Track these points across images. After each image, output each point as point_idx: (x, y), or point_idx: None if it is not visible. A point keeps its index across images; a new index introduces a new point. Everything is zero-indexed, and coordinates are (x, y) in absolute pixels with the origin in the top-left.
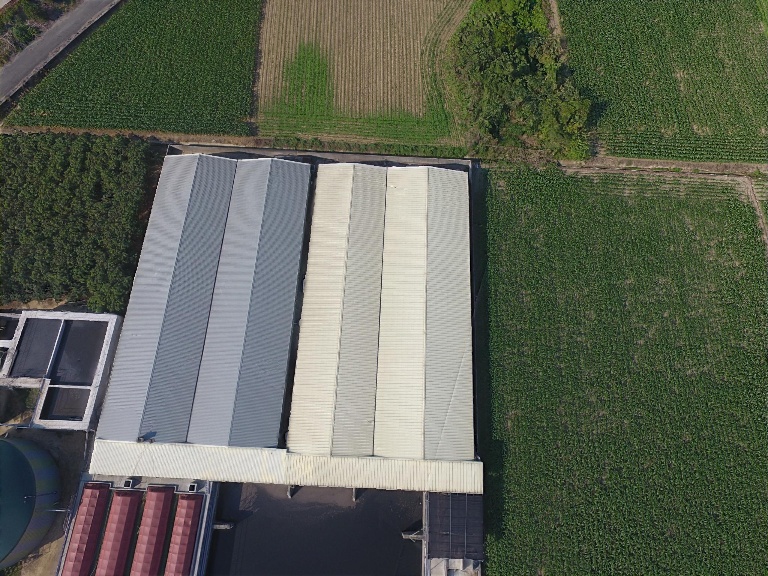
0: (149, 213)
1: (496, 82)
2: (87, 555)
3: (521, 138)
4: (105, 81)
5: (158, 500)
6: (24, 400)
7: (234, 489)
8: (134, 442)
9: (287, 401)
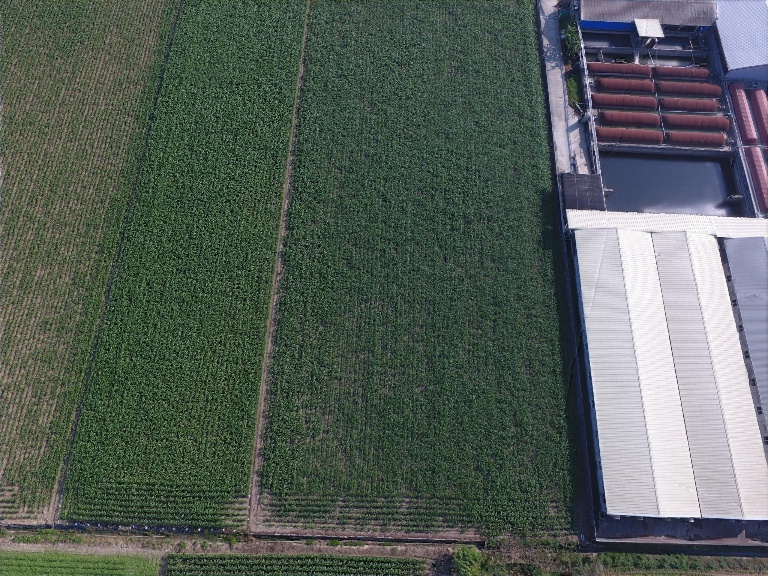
0: None
1: None
2: None
3: None
4: None
5: None
6: None
7: None
8: None
9: None
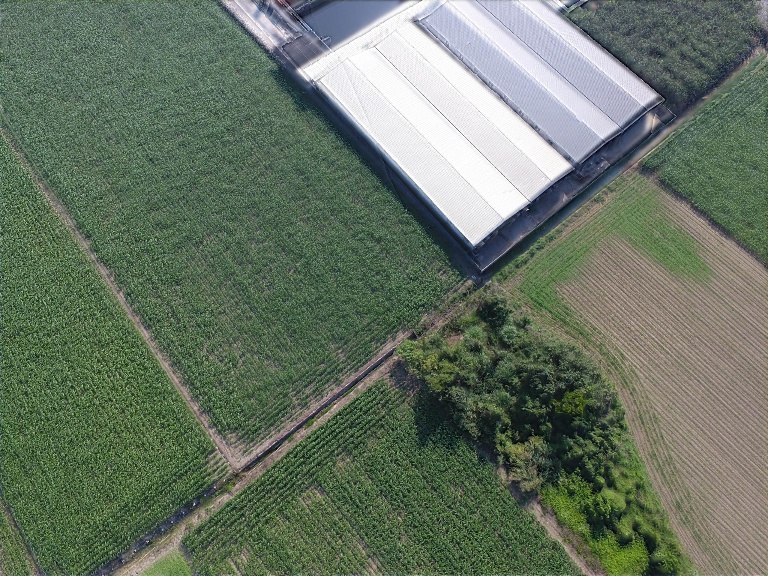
0: None
1: None
2: None
3: None
4: None
5: None
6: None
7: None
8: None
9: None
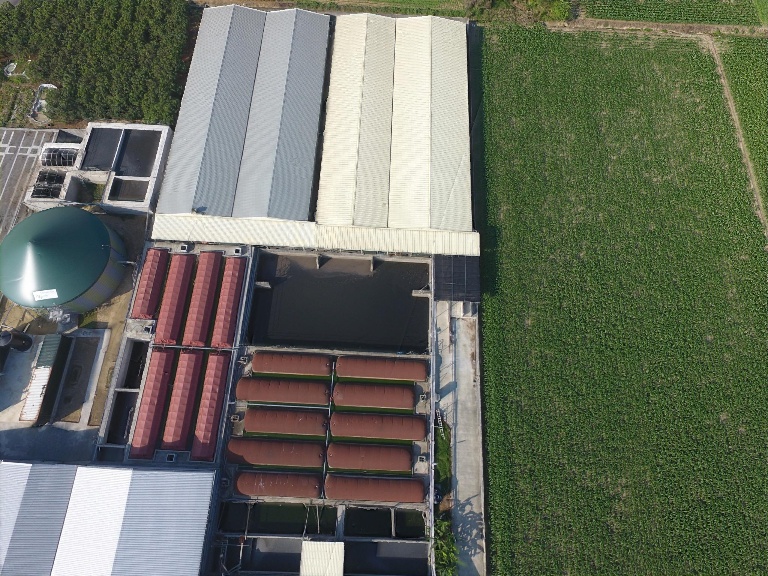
0: (190, 58)
1: None
2: (153, 297)
3: (512, 4)
4: None
5: (210, 258)
6: (92, 192)
7: (271, 262)
8: (189, 213)
9: (314, 196)
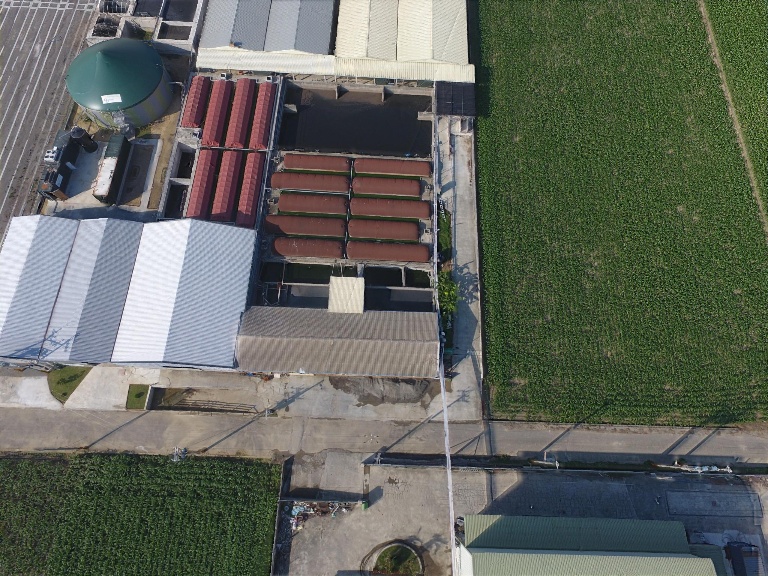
0: None
1: None
2: (199, 111)
3: None
4: None
5: (246, 82)
6: (142, 37)
7: (296, 93)
8: (227, 46)
9: (332, 43)
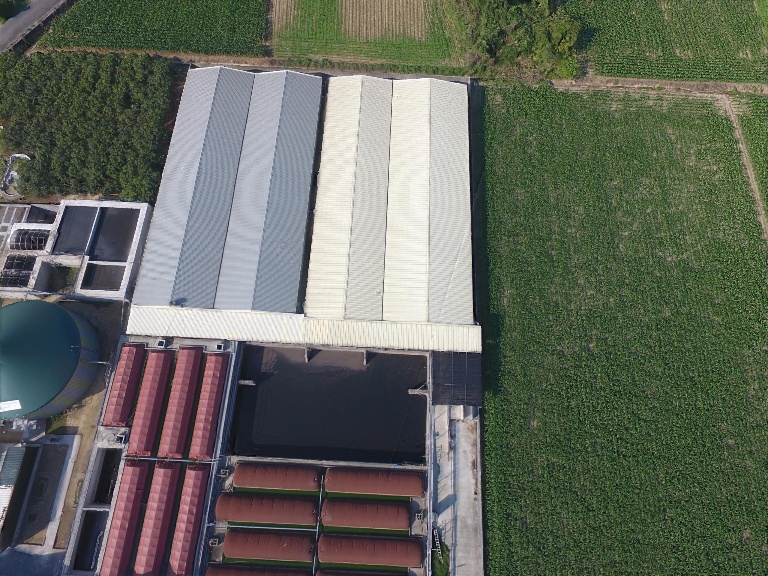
0: (173, 122)
1: (493, 8)
2: (126, 401)
3: (516, 60)
4: (130, 8)
5: (189, 356)
6: (65, 277)
7: (256, 354)
8: (167, 306)
9: (303, 280)
